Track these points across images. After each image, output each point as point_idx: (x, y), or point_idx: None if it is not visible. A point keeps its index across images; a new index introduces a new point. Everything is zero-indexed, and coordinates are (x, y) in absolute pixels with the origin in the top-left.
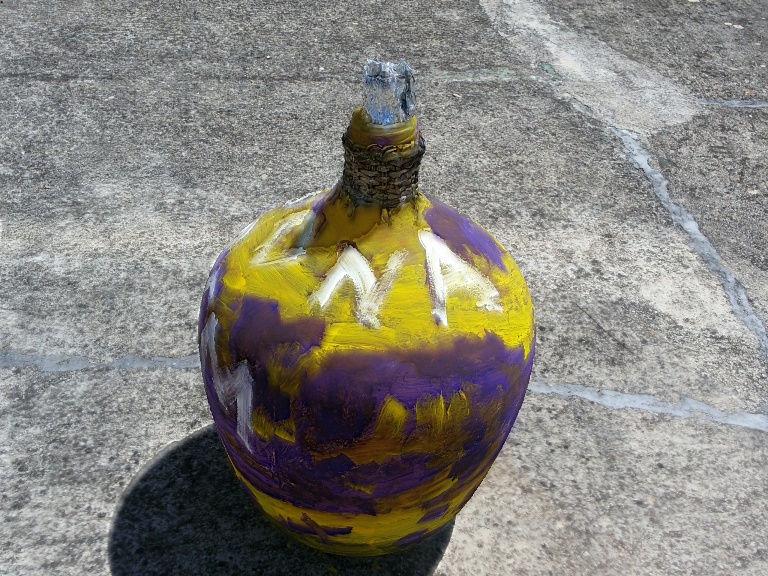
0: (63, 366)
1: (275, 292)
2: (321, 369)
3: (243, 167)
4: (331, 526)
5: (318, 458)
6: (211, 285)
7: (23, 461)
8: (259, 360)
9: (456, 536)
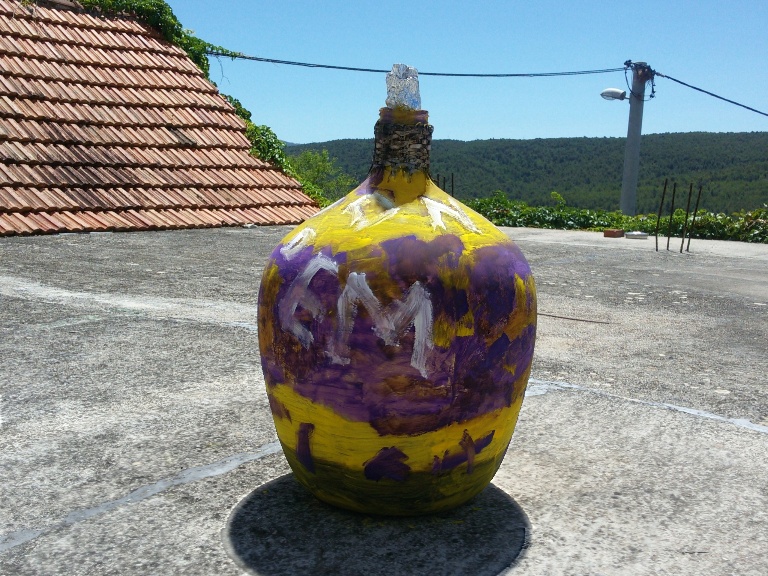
0: (12, 542)
1: (405, 232)
2: (477, 263)
3: None
4: (482, 437)
5: (489, 344)
6: (324, 265)
7: None
8: (430, 275)
9: (491, 480)
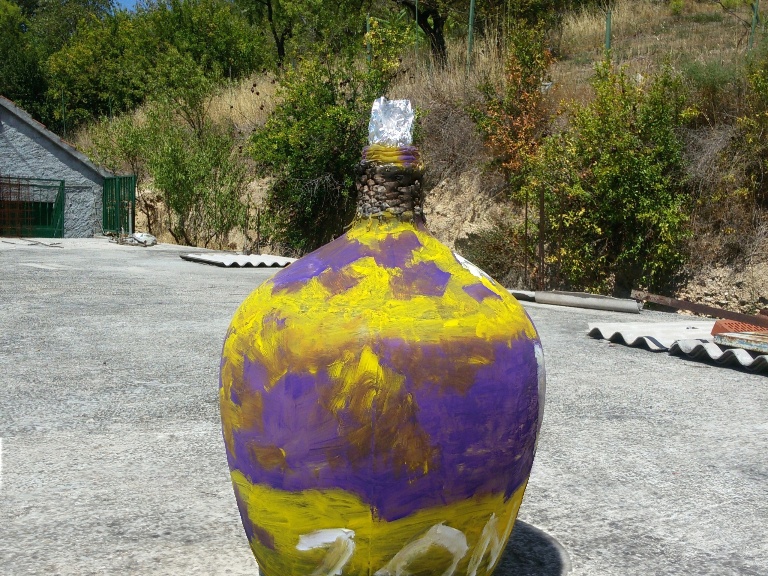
0: None
1: None
2: None
3: None
4: None
5: None
6: None
7: (658, 540)
8: None
9: (254, 571)
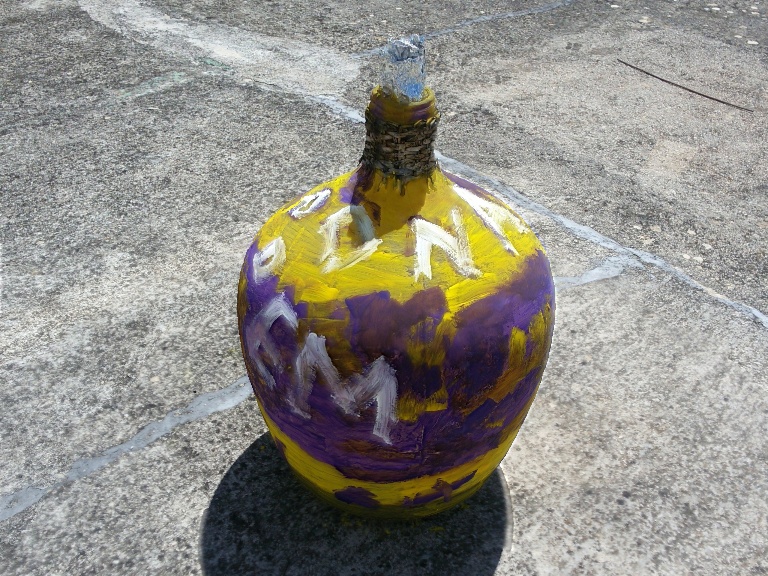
0: (15, 507)
1: (379, 285)
2: (460, 330)
3: (8, 243)
4: (460, 478)
5: (467, 413)
6: (285, 312)
7: None
8: (398, 349)
9: None
